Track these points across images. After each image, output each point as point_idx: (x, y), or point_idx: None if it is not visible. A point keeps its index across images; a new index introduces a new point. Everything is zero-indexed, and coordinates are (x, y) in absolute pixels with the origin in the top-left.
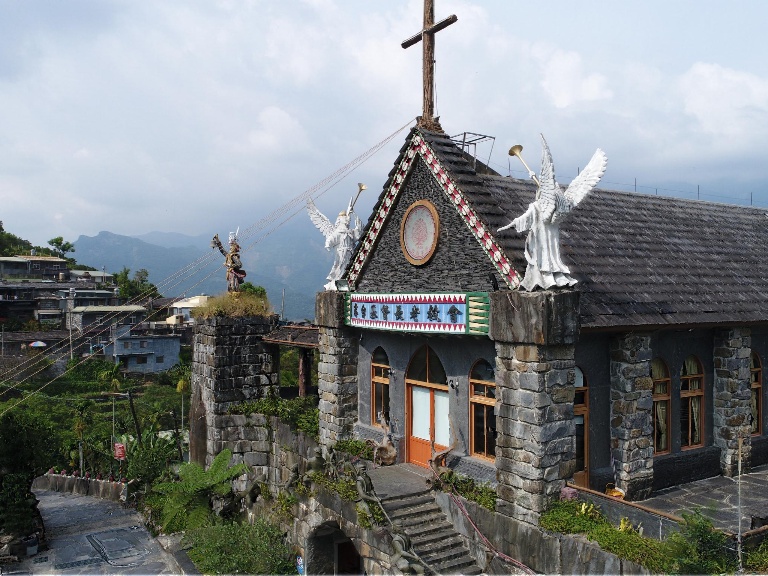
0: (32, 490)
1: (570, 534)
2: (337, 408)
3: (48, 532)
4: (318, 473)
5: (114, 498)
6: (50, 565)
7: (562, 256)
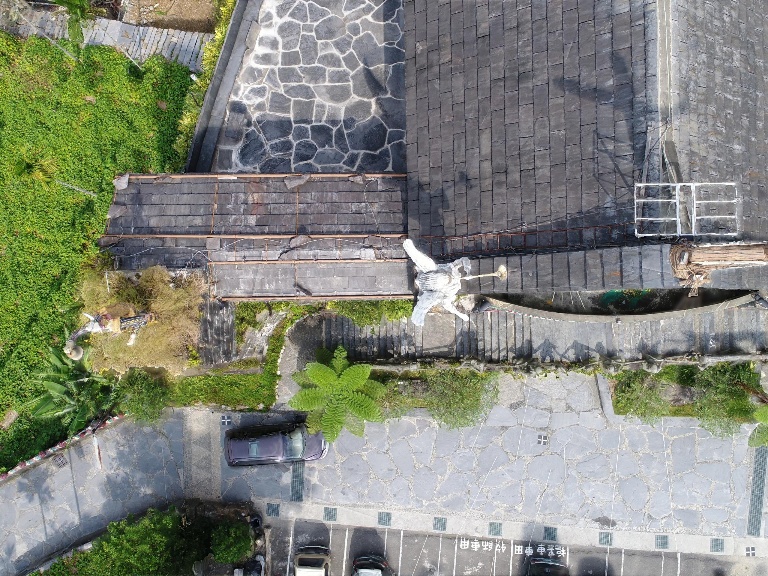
0: (8, 491)
1: None
2: None
3: (198, 496)
4: None
5: None
6: (290, 505)
7: (760, 196)
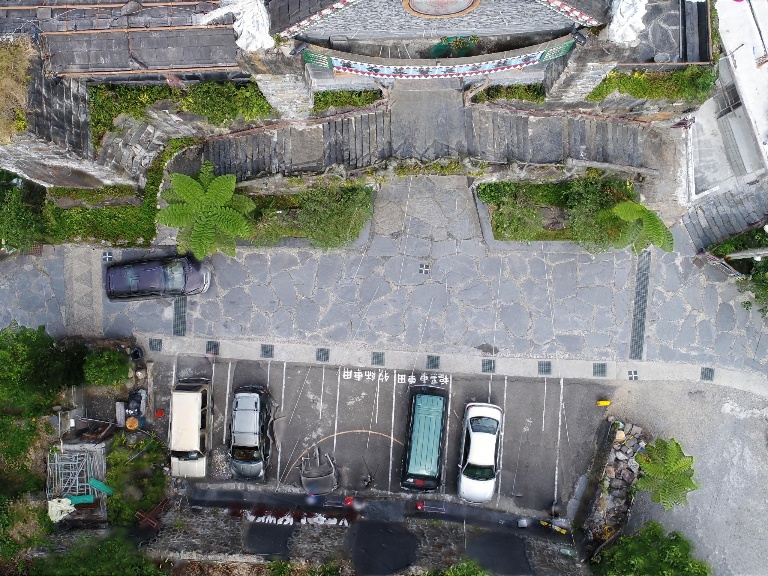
0: None
1: (608, 96)
2: (309, 98)
3: (80, 333)
4: (398, 169)
5: (2, 259)
6: (173, 339)
7: None
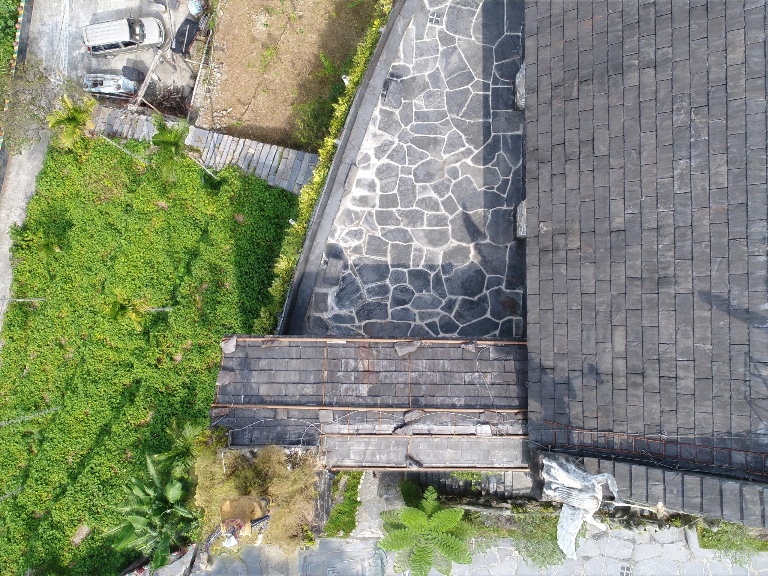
0: None
1: None
2: None
3: None
4: None
5: None
6: None
7: None
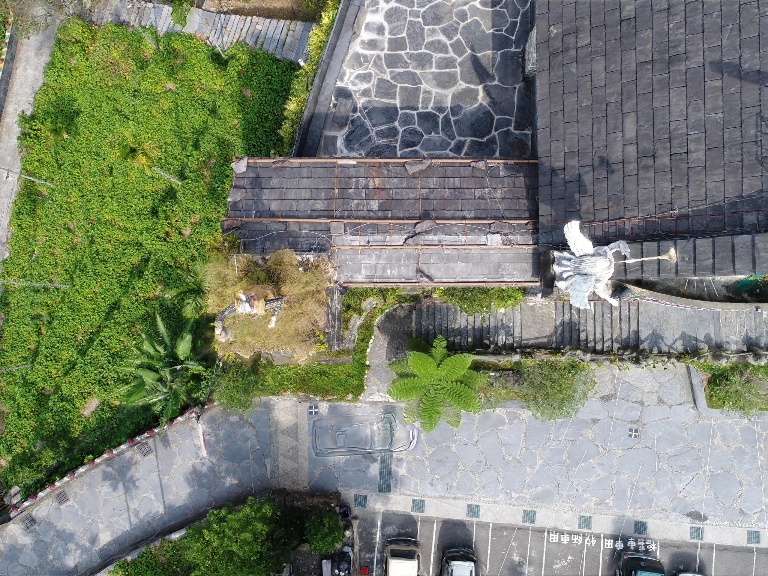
0: (92, 479)
1: None
2: None
3: (284, 486)
4: None
5: None
6: (378, 496)
7: None
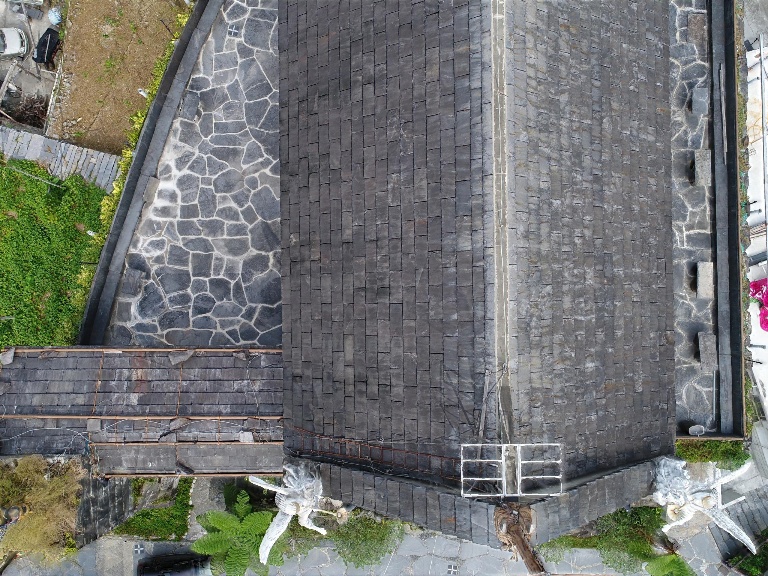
0: None
1: None
2: None
3: None
4: None
5: None
6: None
7: (618, 405)
